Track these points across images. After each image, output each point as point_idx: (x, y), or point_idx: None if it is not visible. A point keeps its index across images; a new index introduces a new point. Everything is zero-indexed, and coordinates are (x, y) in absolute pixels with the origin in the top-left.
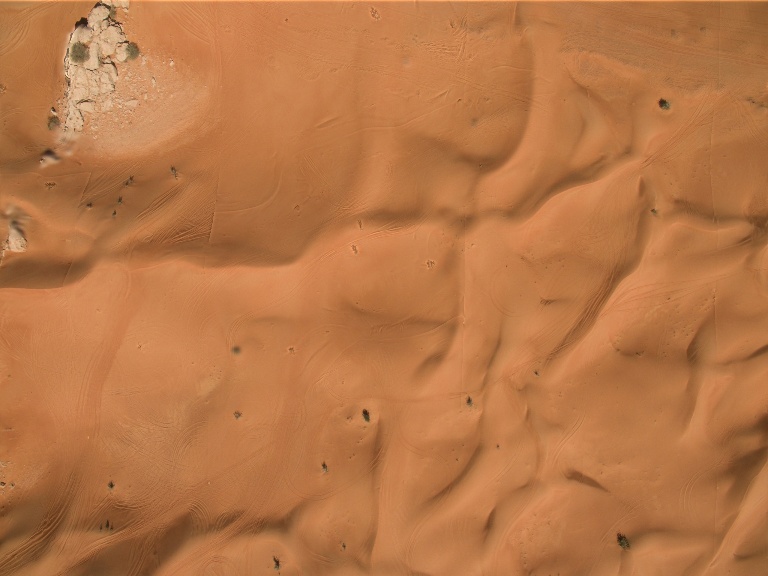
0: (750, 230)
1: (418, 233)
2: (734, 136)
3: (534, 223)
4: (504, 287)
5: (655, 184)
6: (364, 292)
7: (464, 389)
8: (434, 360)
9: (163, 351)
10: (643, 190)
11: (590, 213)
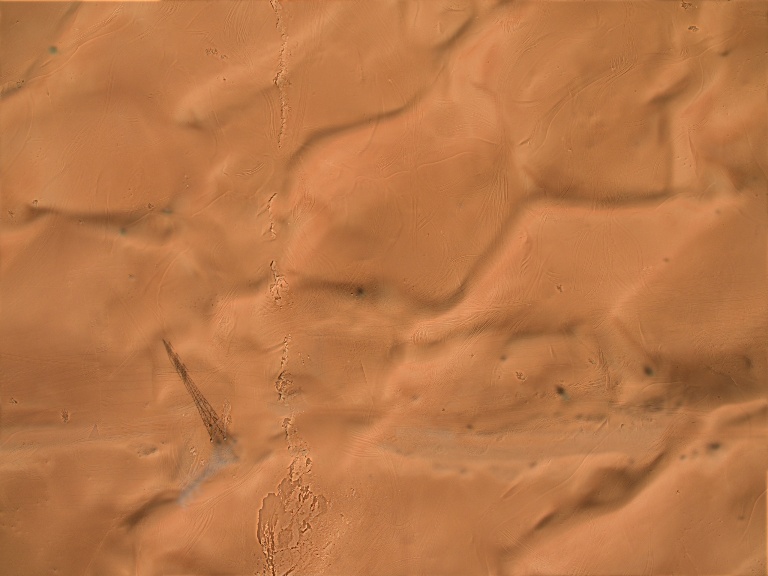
0: None
1: None
2: None
3: (750, 532)
4: None
5: None
6: None
7: None
8: None
9: None
10: None
11: None
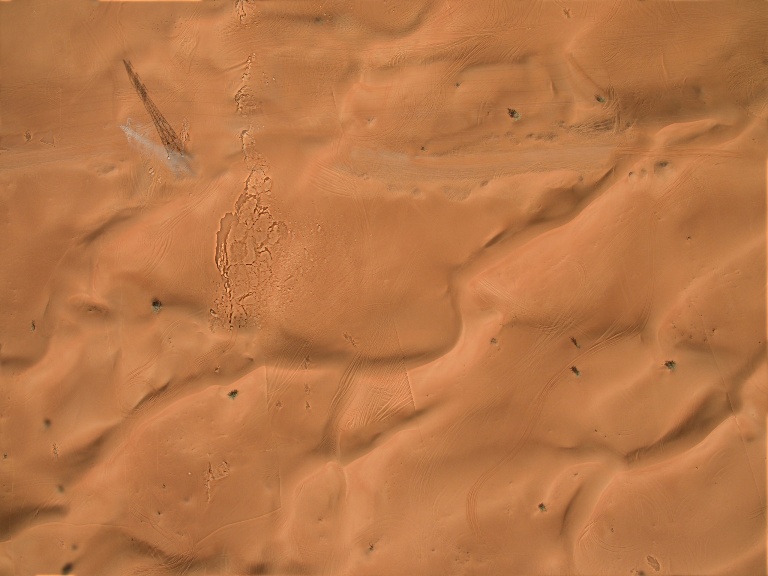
0: None
1: (644, 334)
2: None
3: None
4: (766, 368)
5: None
6: (599, 416)
7: (764, 503)
8: (718, 478)
9: (398, 545)
10: None
11: None
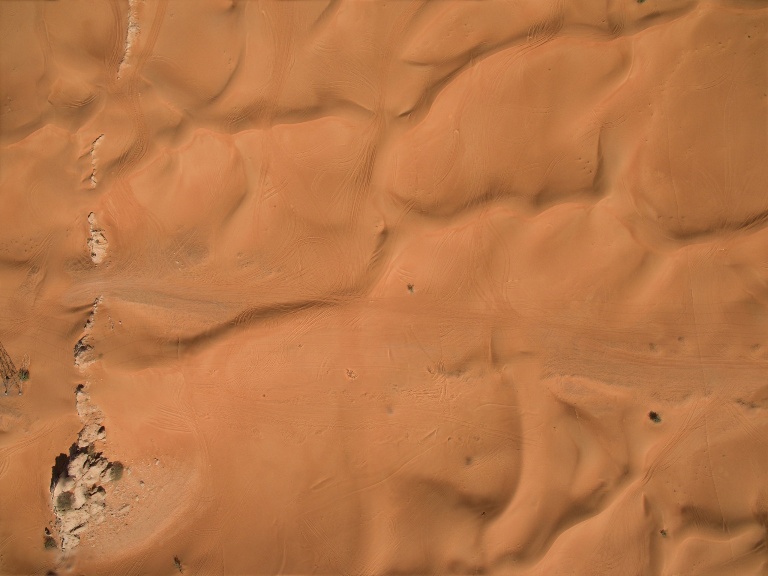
0: (762, 533)
1: None
2: (730, 435)
3: (546, 562)
4: None
5: (659, 500)
6: None
7: None
8: None
9: None
10: (648, 509)
11: (600, 540)
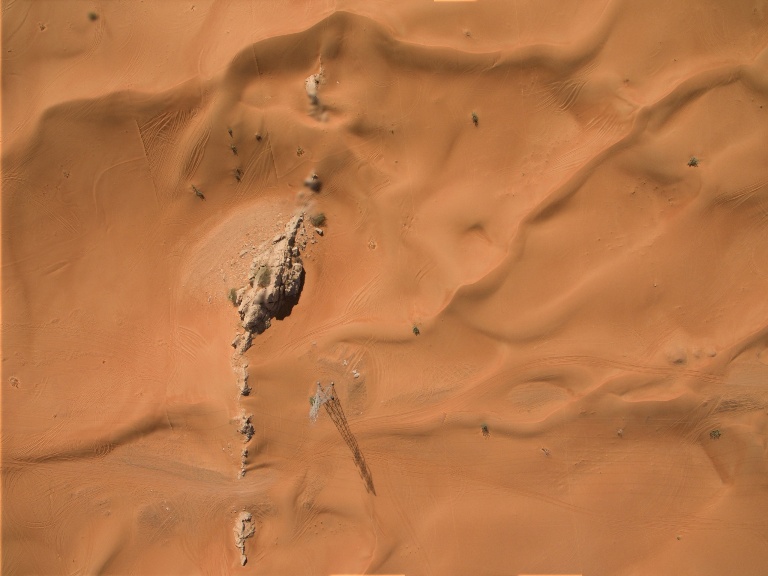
0: None
1: None
2: None
3: None
4: None
5: None
6: None
7: None
8: None
9: (172, 8)
10: None
11: None
